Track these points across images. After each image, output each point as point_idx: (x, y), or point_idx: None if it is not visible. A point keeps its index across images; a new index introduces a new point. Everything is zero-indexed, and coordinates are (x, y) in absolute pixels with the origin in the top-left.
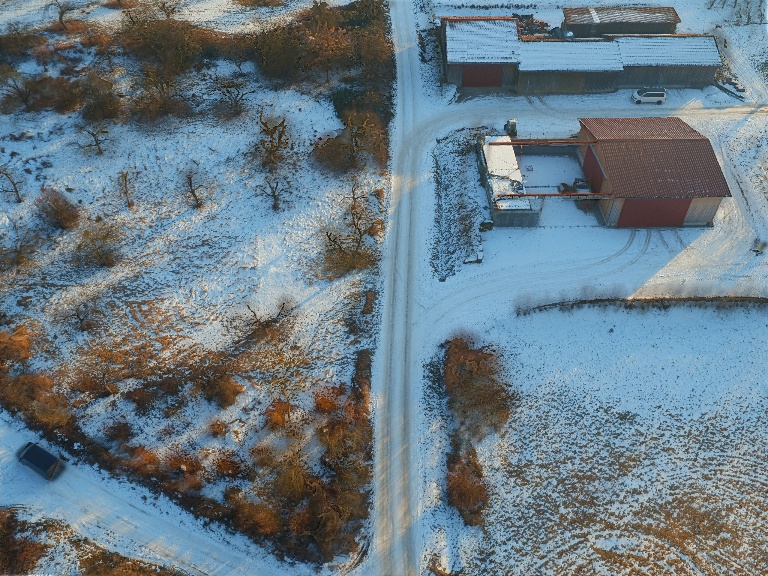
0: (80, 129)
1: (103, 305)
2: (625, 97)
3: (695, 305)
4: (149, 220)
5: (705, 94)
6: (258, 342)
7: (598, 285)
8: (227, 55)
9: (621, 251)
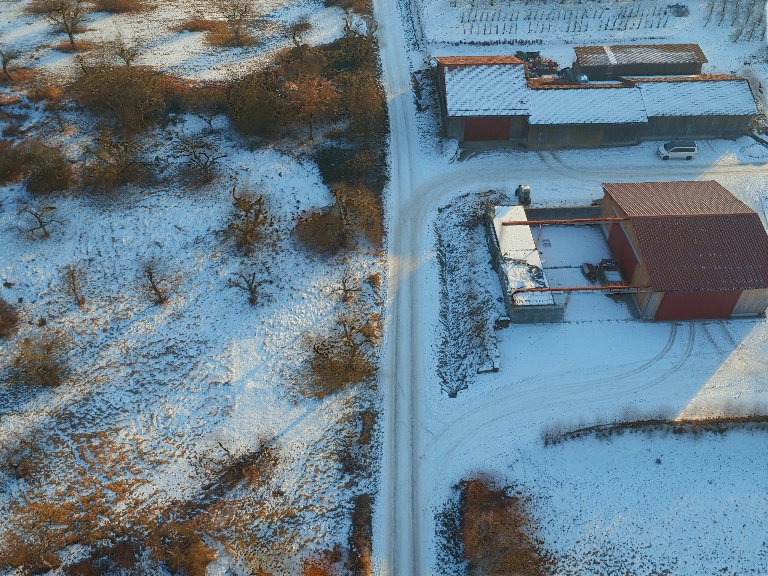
0: (21, 210)
1: (44, 441)
2: (649, 151)
3: (757, 427)
4: (103, 322)
5: (739, 146)
6: (233, 487)
7: (639, 401)
8: (195, 111)
9: (662, 353)
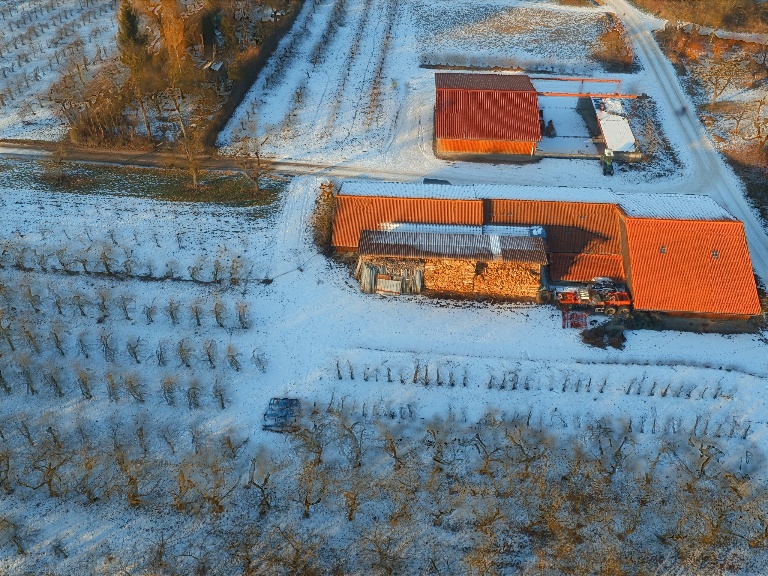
0: None
1: None
2: None
3: None
4: None
5: None
6: None
7: None
8: None
9: None
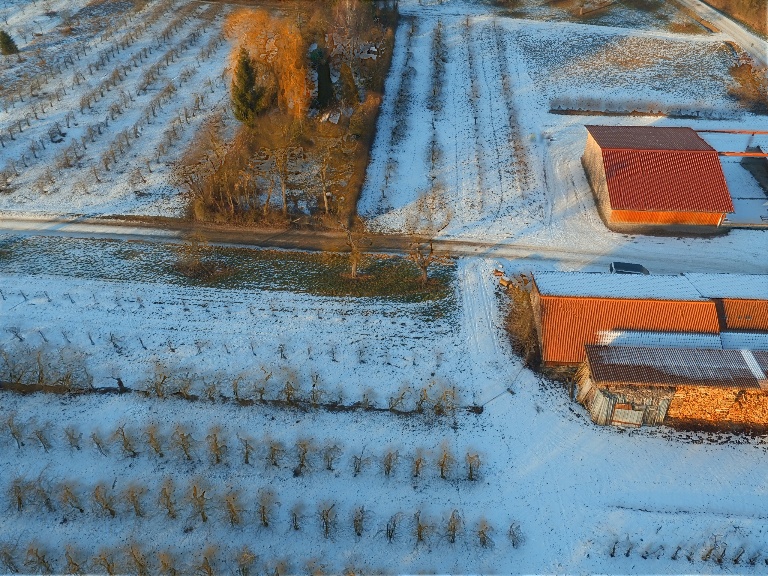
0: None
1: None
2: None
3: None
4: None
5: None
6: None
7: (683, 126)
8: None
9: None
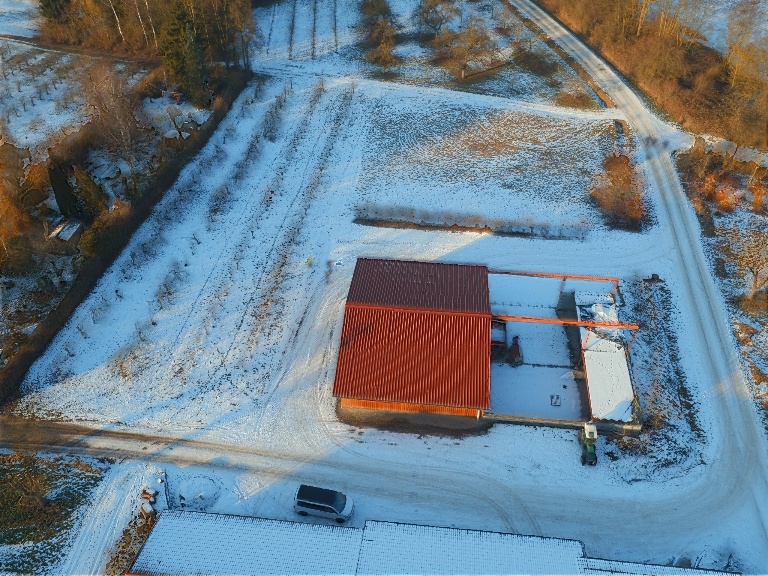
0: None
1: None
2: (360, 526)
3: None
4: None
5: None
6: None
7: (508, 248)
8: None
9: None
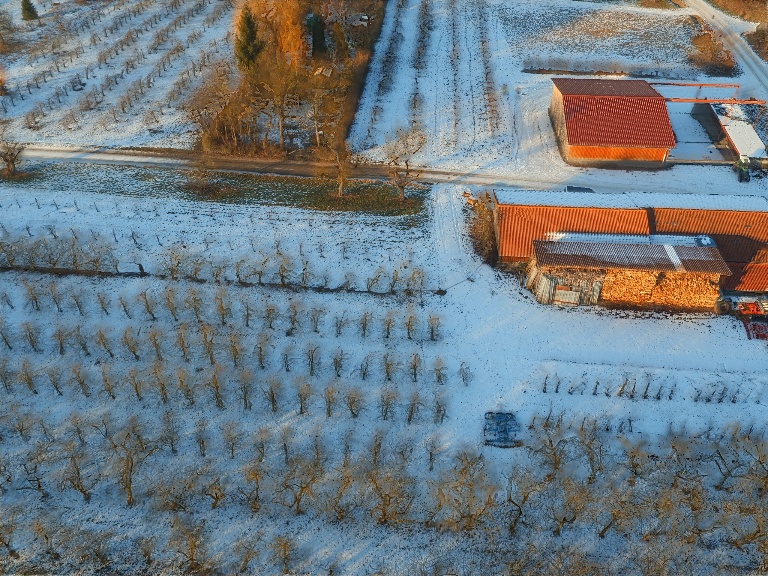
0: None
1: None
2: None
3: None
4: None
5: None
6: None
7: None
8: None
9: None
